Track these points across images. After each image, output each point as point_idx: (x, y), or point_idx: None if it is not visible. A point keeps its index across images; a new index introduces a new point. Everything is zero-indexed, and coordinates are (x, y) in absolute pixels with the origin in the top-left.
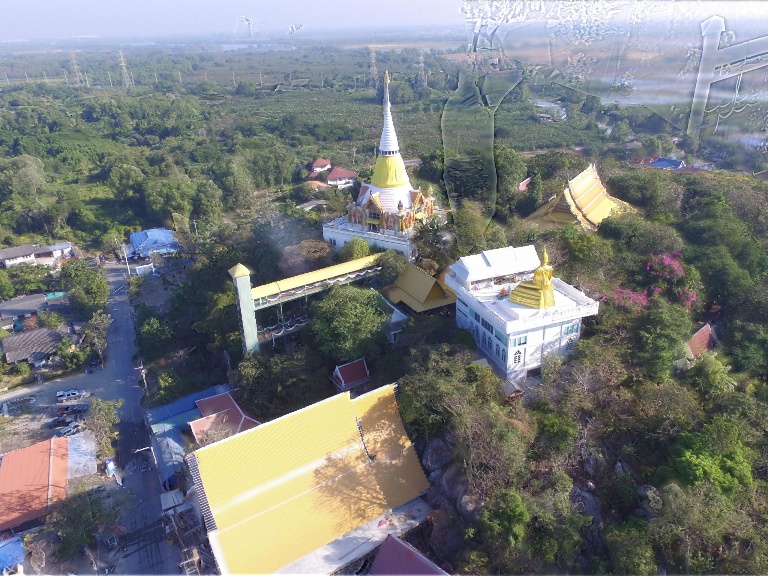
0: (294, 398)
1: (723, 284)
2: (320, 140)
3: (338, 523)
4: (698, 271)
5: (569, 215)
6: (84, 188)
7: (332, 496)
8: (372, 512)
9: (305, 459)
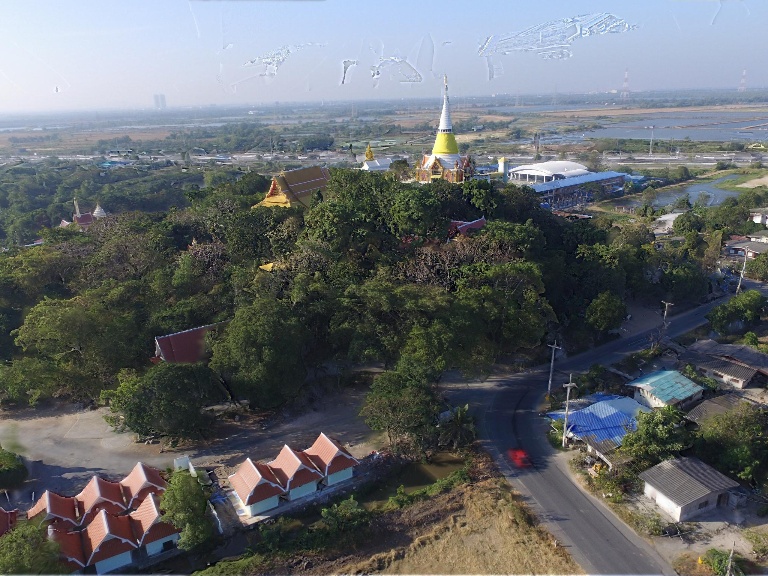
0: None
1: None
2: None
3: None
4: None
5: None
6: None
7: None
8: None
9: None
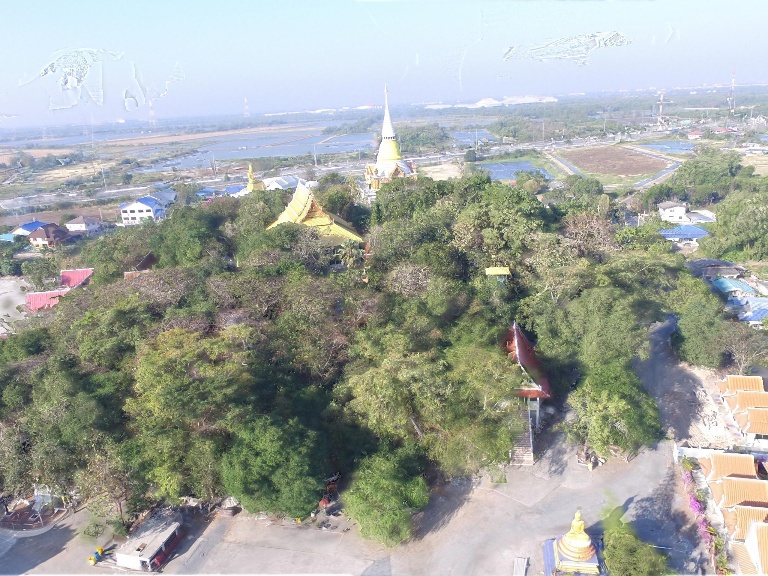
0: None
1: None
2: None
3: None
4: None
5: None
6: None
7: None
8: None
9: None
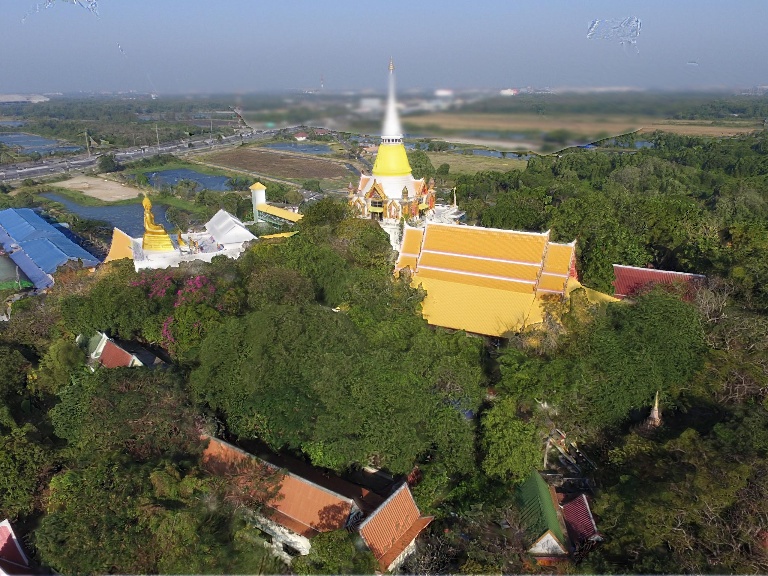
0: None
1: None
2: None
3: None
4: None
5: None
6: None
7: None
8: None
9: None
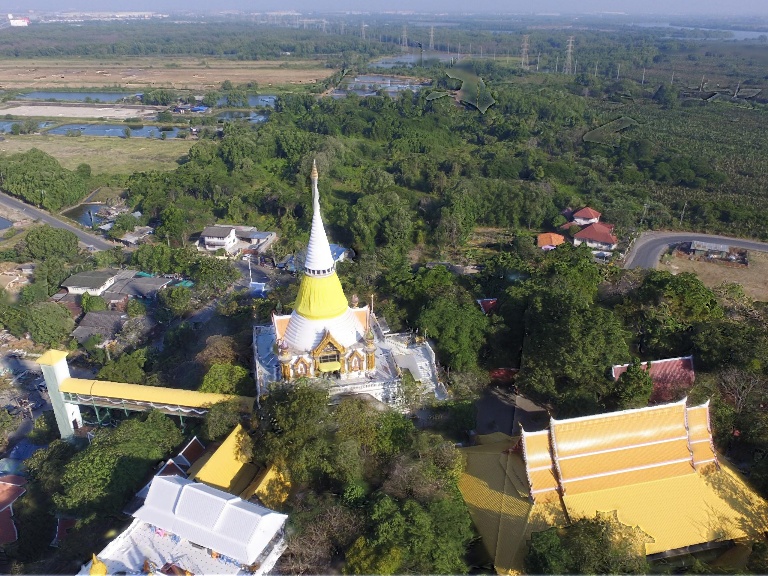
0: None
1: None
2: (656, 178)
3: None
4: None
5: (526, 477)
6: None
7: None
8: None
9: None
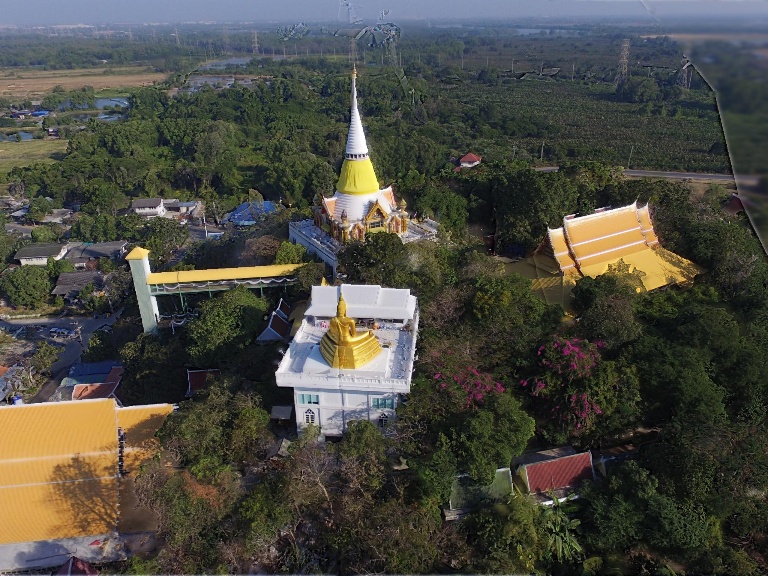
0: (147, 390)
1: (675, 403)
2: (508, 134)
3: (57, 525)
4: (638, 375)
5: (553, 262)
6: (262, 155)
7: (65, 497)
8: (96, 528)
9: (50, 452)
